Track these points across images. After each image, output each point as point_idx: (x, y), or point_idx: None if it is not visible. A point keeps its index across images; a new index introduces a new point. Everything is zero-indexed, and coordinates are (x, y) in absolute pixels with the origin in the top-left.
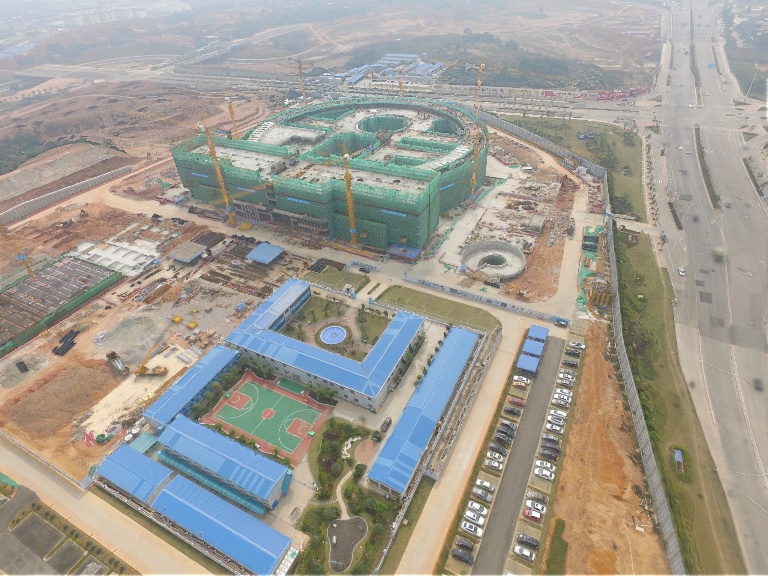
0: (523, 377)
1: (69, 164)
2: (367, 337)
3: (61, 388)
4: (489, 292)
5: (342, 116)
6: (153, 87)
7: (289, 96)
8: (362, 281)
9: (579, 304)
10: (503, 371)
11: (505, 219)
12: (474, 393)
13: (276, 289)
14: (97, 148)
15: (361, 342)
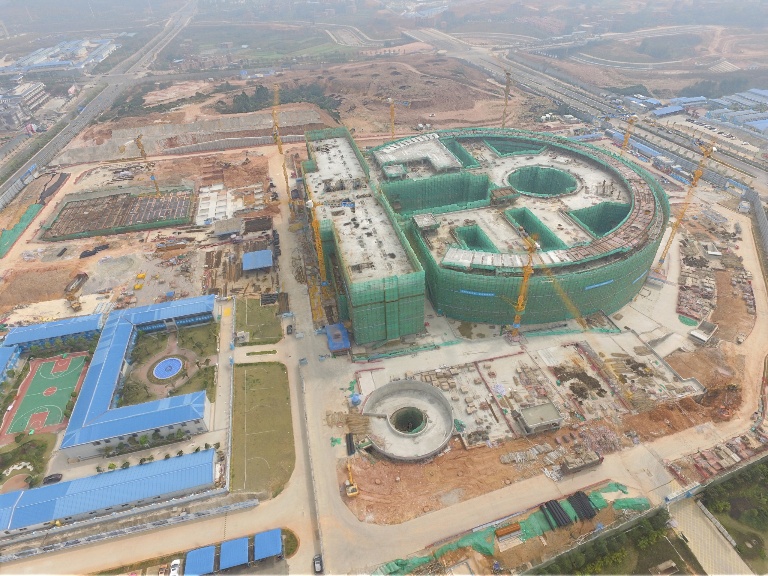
0: (175, 570)
1: (286, 119)
2: (175, 392)
3: (38, 279)
4: (334, 449)
5: (517, 153)
6: (450, 68)
7: (559, 110)
8: (269, 338)
9: (383, 568)
10: (186, 542)
11: (520, 381)
12: (126, 531)
13: (220, 297)
14: (314, 112)
15: (168, 392)
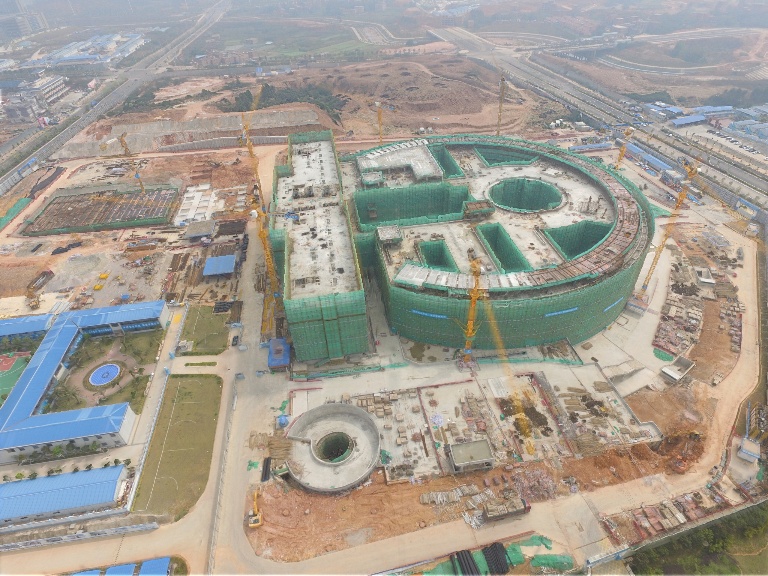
0: None
1: (284, 119)
2: (104, 400)
3: (5, 275)
4: (248, 473)
5: (506, 163)
6: (465, 69)
7: (571, 117)
8: (213, 349)
9: None
10: (76, 562)
11: (462, 412)
12: (20, 545)
13: (175, 302)
14: (313, 112)
15: (98, 400)
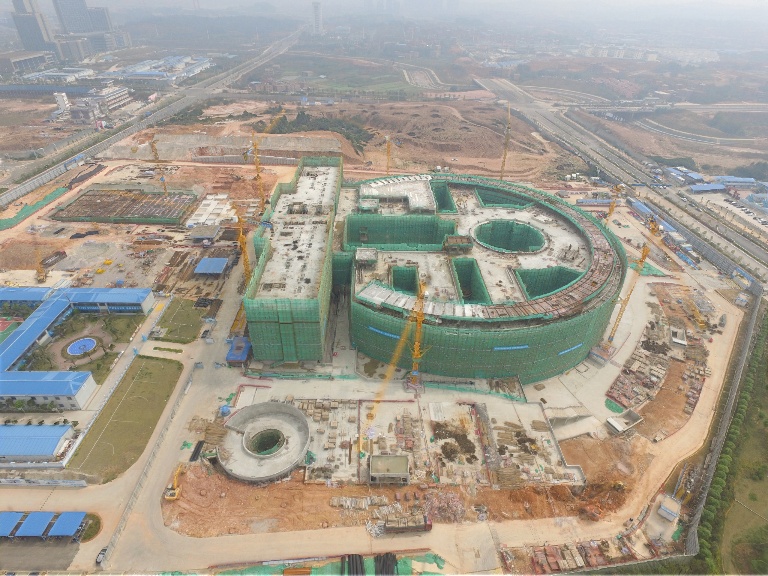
0: None
1: (309, 144)
2: (74, 369)
3: (25, 250)
4: (180, 452)
5: (500, 205)
6: (496, 117)
7: (588, 172)
8: (183, 338)
9: (158, 575)
10: (7, 504)
11: (395, 429)
12: None
13: None
14: (337, 141)
15: None
